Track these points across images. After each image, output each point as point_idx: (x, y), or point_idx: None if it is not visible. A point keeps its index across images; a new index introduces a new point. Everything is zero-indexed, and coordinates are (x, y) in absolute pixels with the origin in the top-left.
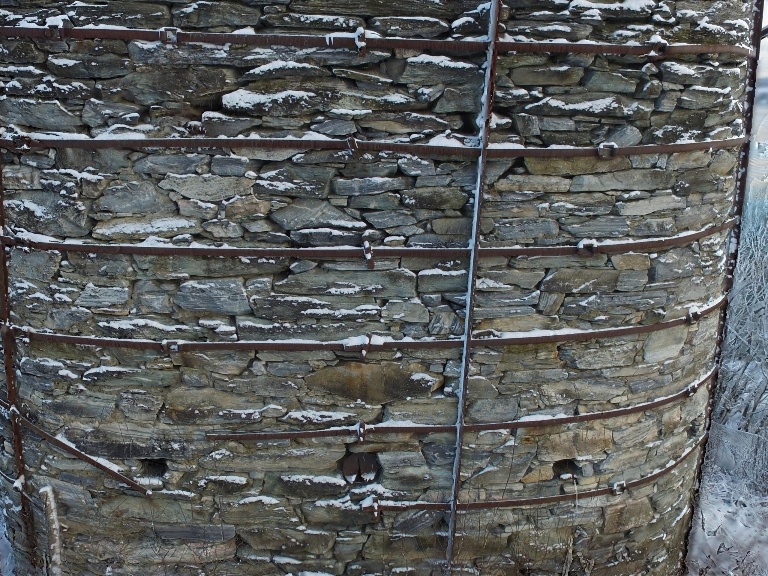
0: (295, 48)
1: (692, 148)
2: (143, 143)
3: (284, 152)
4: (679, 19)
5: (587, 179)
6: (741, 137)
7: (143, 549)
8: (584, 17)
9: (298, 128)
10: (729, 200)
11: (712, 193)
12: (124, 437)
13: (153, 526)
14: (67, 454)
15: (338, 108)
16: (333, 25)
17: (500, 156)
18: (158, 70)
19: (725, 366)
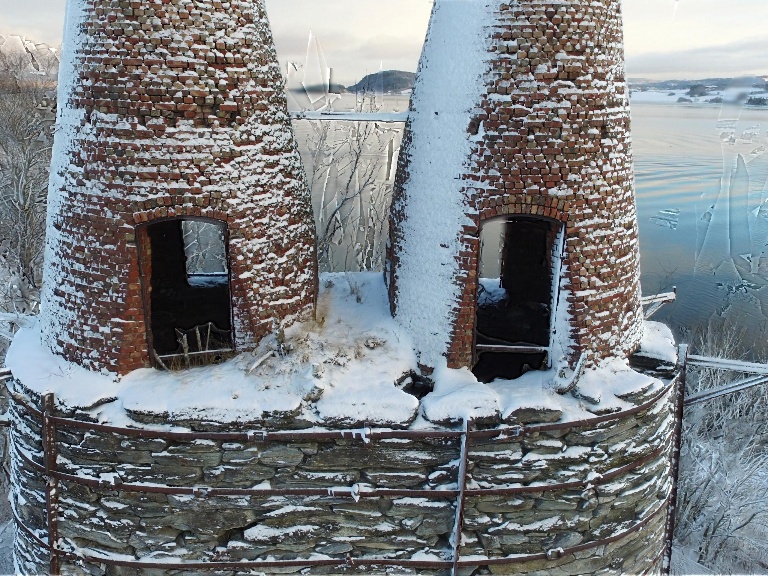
0: (303, 496)
1: (625, 535)
2: (179, 566)
3: (294, 567)
4: (611, 454)
5: (539, 574)
6: (668, 494)
7: None
8: (534, 467)
9: (305, 549)
10: (660, 540)
11: (644, 550)
12: None
13: None
14: None
15: (338, 536)
16: (334, 480)
17: (469, 565)
18: (192, 513)
19: (689, 479)
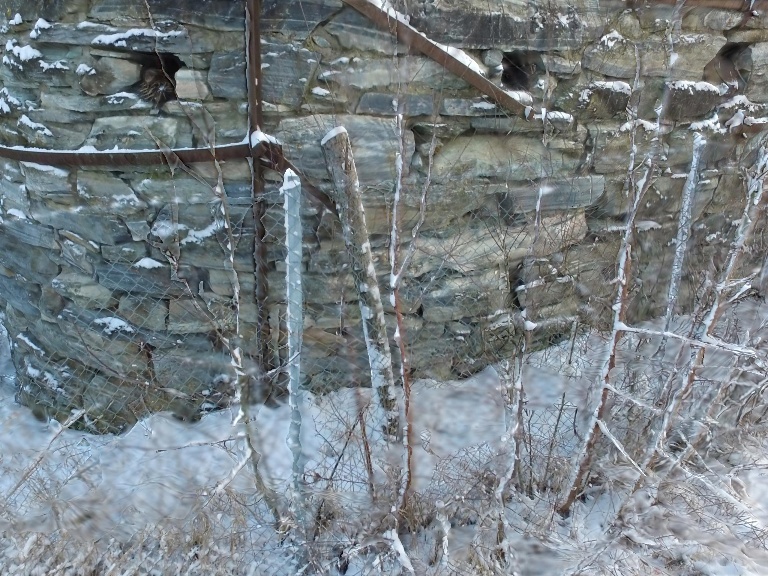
0: None
1: None
2: None
3: None
4: None
5: None
6: None
7: (479, 242)
8: None
9: None
10: None
11: None
12: (490, 1)
13: (507, 190)
14: (387, 44)
15: None
16: None
17: None
18: None
19: None
